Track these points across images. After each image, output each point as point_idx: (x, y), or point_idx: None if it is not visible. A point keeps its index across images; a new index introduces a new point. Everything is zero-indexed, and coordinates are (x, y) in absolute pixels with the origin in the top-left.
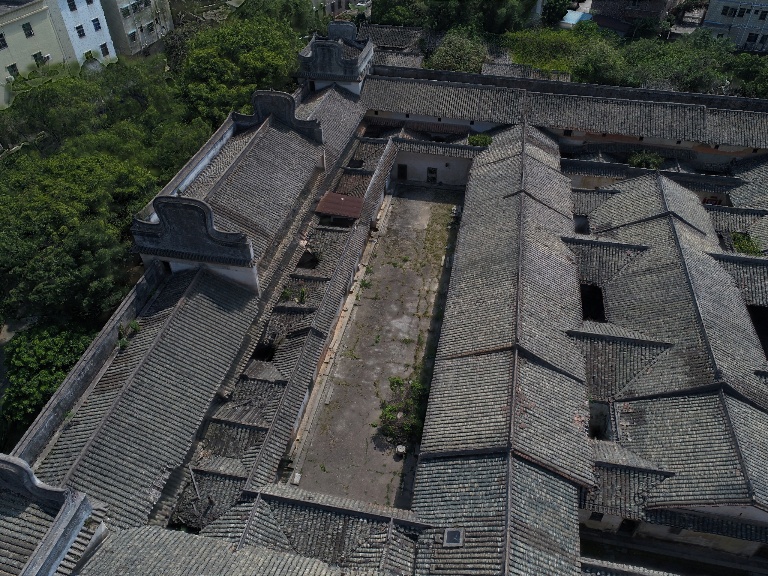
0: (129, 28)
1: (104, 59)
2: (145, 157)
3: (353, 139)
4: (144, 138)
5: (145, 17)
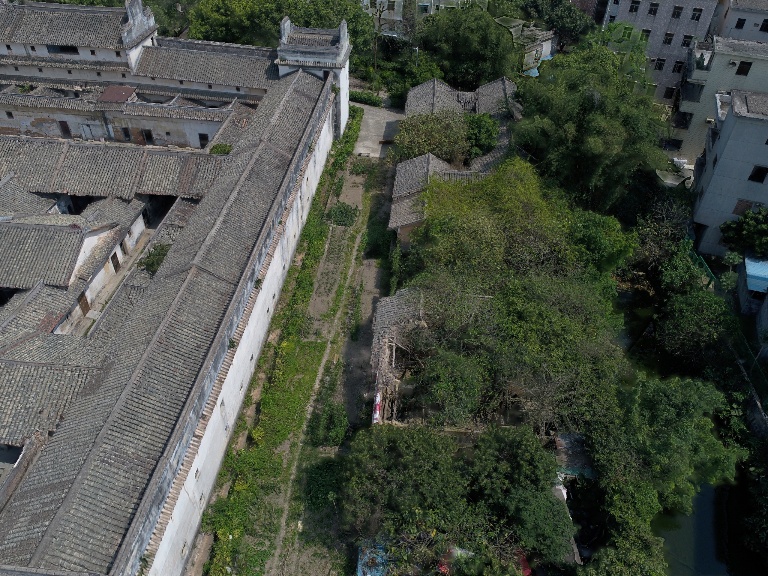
0: (423, 0)
1: (388, 12)
2: (115, 4)
3: (233, 97)
4: (151, 4)
5: (448, 0)
